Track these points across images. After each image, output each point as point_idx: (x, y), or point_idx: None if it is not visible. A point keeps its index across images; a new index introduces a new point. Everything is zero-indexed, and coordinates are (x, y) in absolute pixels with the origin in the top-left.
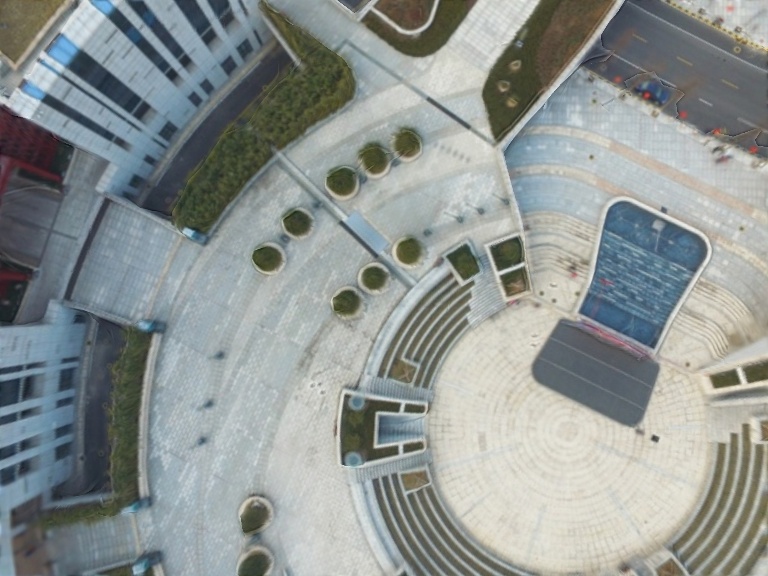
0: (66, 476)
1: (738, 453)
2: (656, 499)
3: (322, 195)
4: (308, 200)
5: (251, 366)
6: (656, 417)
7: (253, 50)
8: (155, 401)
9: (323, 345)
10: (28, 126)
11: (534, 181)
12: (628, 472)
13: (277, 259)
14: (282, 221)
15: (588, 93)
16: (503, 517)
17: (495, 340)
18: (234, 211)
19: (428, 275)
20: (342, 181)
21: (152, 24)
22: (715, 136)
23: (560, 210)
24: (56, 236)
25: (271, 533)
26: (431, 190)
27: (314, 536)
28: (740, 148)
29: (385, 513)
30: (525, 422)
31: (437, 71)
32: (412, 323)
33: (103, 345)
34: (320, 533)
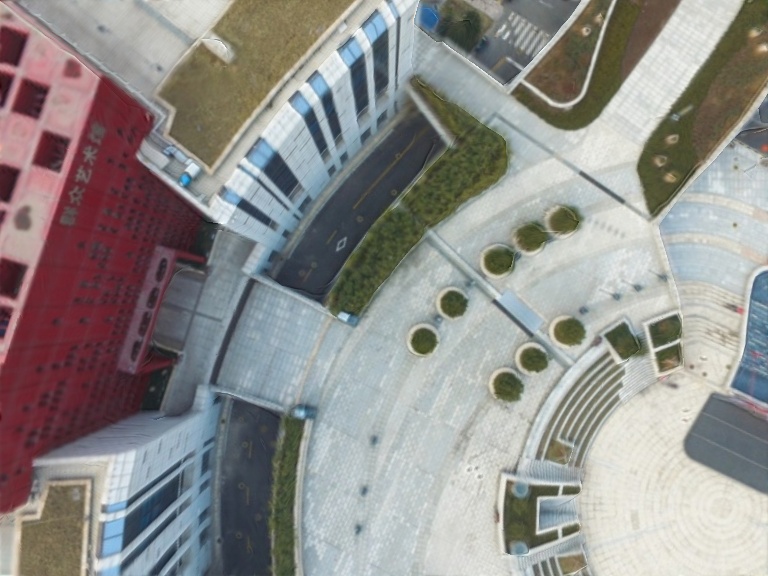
0: (208, 562)
1: None
2: None
3: (475, 273)
4: (460, 278)
5: (406, 450)
6: None
7: (387, 118)
8: (308, 488)
9: (479, 428)
10: (202, 222)
11: (678, 250)
12: None
13: (432, 341)
14: (438, 303)
15: (729, 159)
16: None
17: (646, 415)
18: (384, 290)
19: (586, 355)
20: (504, 263)
21: (330, 115)
22: None
23: (705, 280)
24: (199, 318)
25: None
26: (586, 267)
27: None
28: None
29: None
30: (678, 499)
31: (589, 144)
32: (568, 403)
33: (238, 423)
34: None
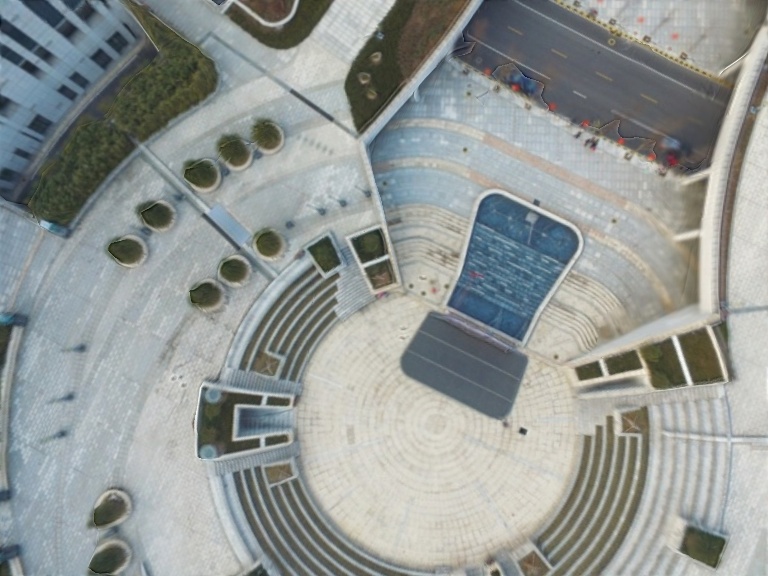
0: None
1: (602, 445)
2: (523, 492)
3: (184, 188)
4: (171, 193)
5: (112, 359)
6: (524, 410)
7: (128, 43)
8: (16, 394)
9: (185, 338)
10: None
11: (407, 174)
12: (496, 465)
13: (137, 252)
14: (141, 213)
15: (463, 86)
16: (371, 510)
17: (364, 333)
18: (97, 204)
19: (289, 267)
20: (197, 173)
21: None
22: (584, 128)
23: (433, 203)
24: None
25: (129, 526)
26: (294, 182)
27: (173, 529)
28: (608, 140)
29: (246, 506)
30: (393, 415)
31: (300, 63)
32: (275, 316)
33: None
34: (179, 526)
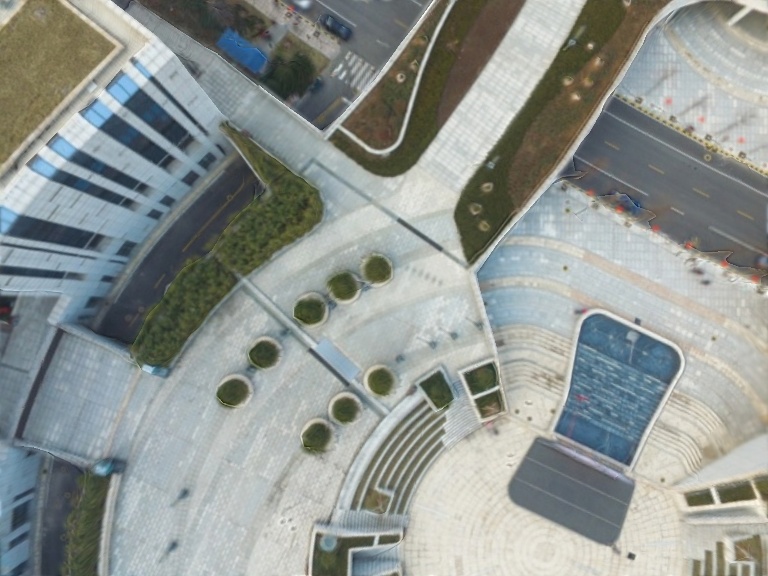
0: None
1: (713, 571)
2: None
3: (290, 322)
4: (275, 327)
5: (218, 503)
6: (632, 534)
7: (216, 159)
8: (116, 544)
9: (293, 479)
10: None
11: (508, 294)
12: None
13: (243, 392)
14: (248, 353)
15: (561, 202)
16: None
17: (471, 461)
18: (197, 340)
19: (401, 404)
20: (310, 314)
21: (102, 171)
22: (687, 250)
23: (535, 323)
24: (5, 369)
25: None
26: (403, 315)
27: None
28: (711, 263)
29: None
30: (502, 544)
31: (407, 191)
32: (385, 452)
33: (60, 473)
34: None
